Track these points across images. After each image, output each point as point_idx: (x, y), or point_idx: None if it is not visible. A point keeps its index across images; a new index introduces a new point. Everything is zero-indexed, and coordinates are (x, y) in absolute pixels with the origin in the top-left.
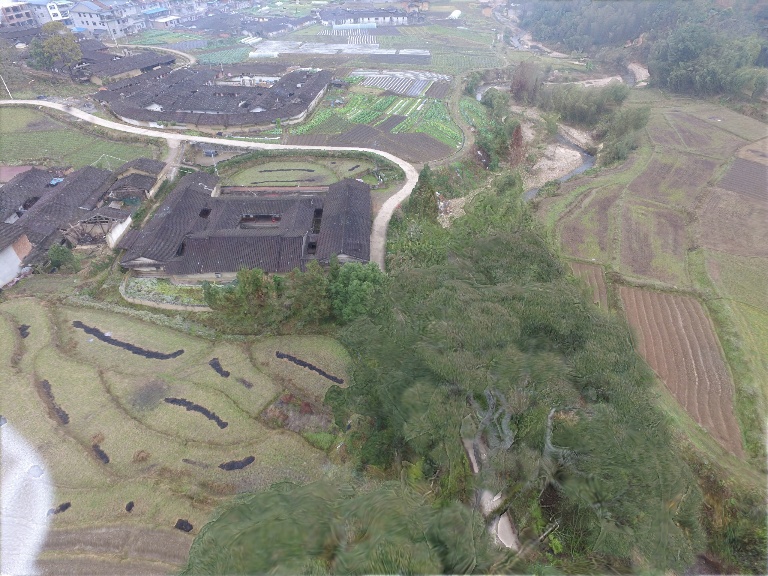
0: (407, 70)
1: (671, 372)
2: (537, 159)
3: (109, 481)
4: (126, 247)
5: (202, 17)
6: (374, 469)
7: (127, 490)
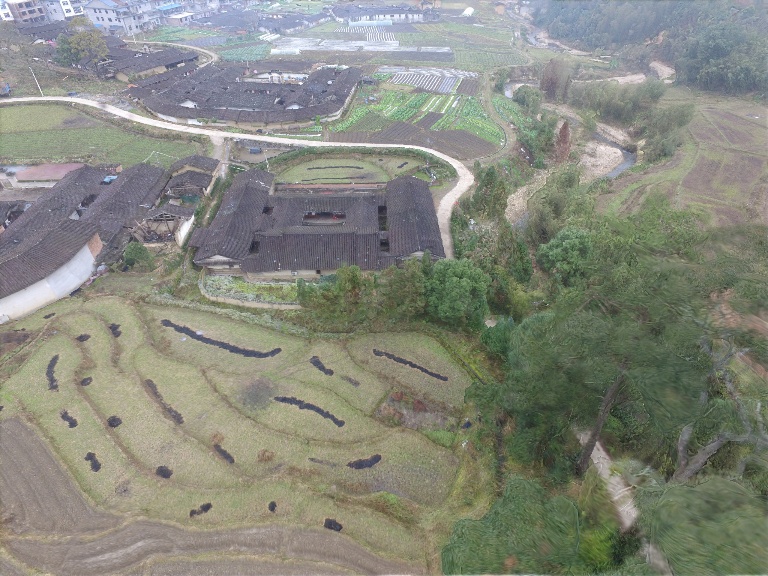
0: (433, 67)
1: None
2: None
3: (242, 481)
4: (198, 245)
5: (215, 14)
6: (513, 466)
7: (265, 490)
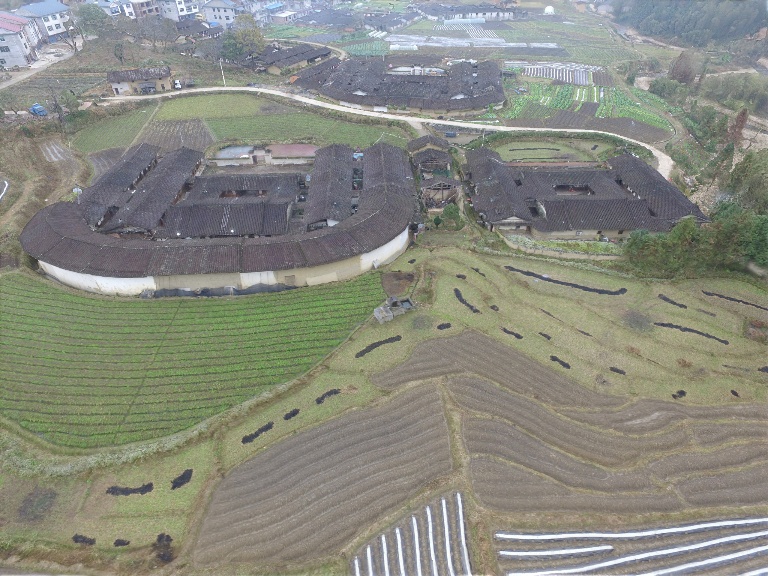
0: (556, 62)
1: None
2: (740, 142)
3: (687, 378)
4: (485, 209)
5: (312, 12)
6: None
7: (720, 382)
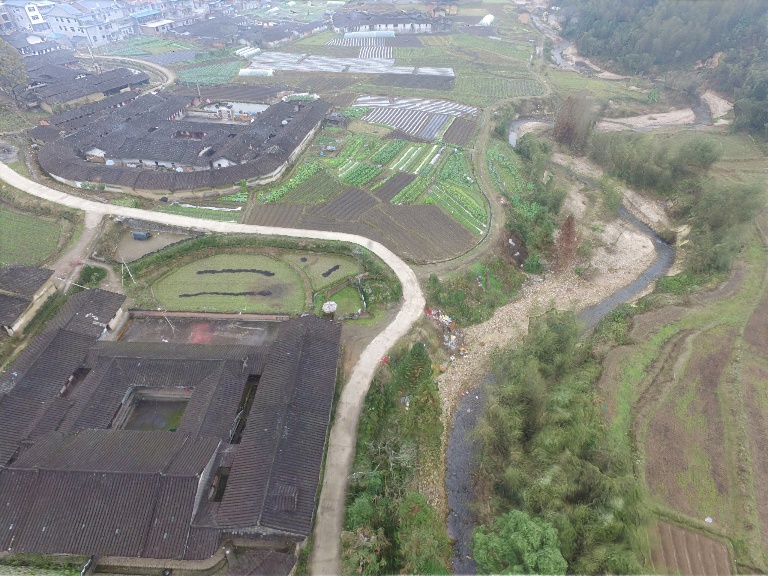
0: (424, 98)
1: None
2: (592, 250)
3: None
4: None
5: (200, 20)
6: None
7: None
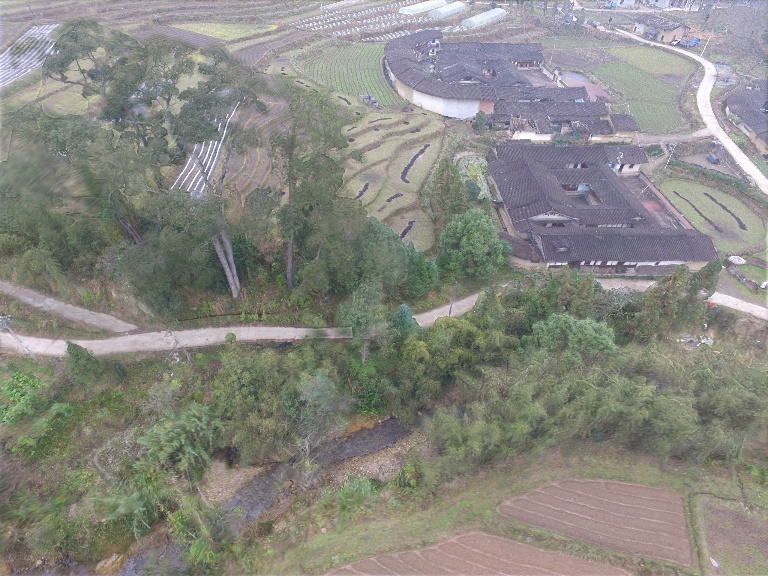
0: None
1: (435, 568)
2: None
3: None
4: None
5: None
6: None
7: None
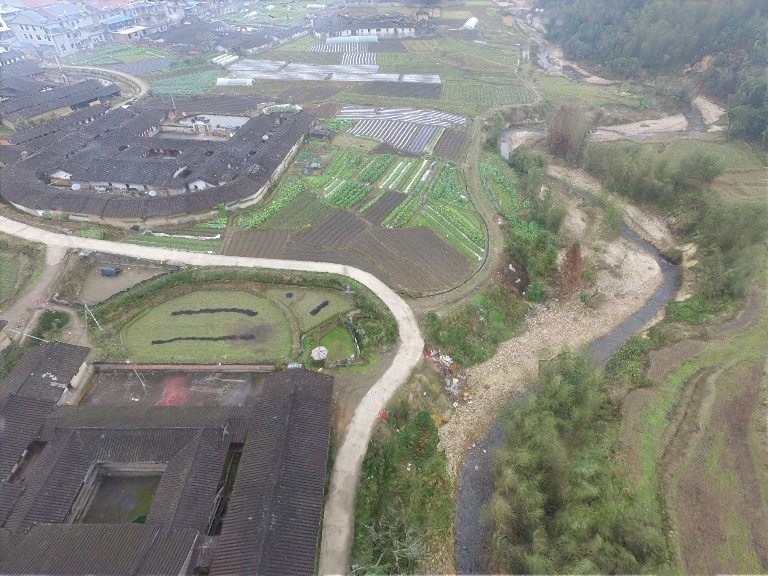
0: (411, 108)
1: None
2: (595, 273)
3: None
4: None
5: (175, 26)
6: None
7: None
